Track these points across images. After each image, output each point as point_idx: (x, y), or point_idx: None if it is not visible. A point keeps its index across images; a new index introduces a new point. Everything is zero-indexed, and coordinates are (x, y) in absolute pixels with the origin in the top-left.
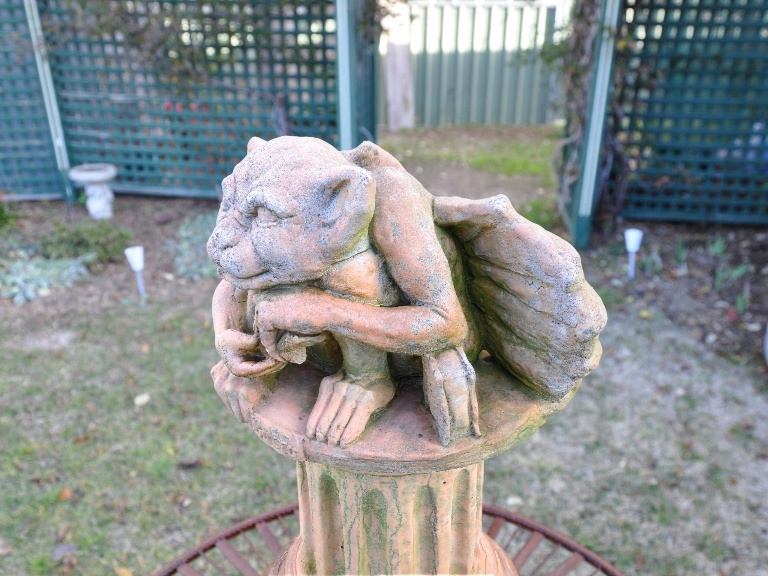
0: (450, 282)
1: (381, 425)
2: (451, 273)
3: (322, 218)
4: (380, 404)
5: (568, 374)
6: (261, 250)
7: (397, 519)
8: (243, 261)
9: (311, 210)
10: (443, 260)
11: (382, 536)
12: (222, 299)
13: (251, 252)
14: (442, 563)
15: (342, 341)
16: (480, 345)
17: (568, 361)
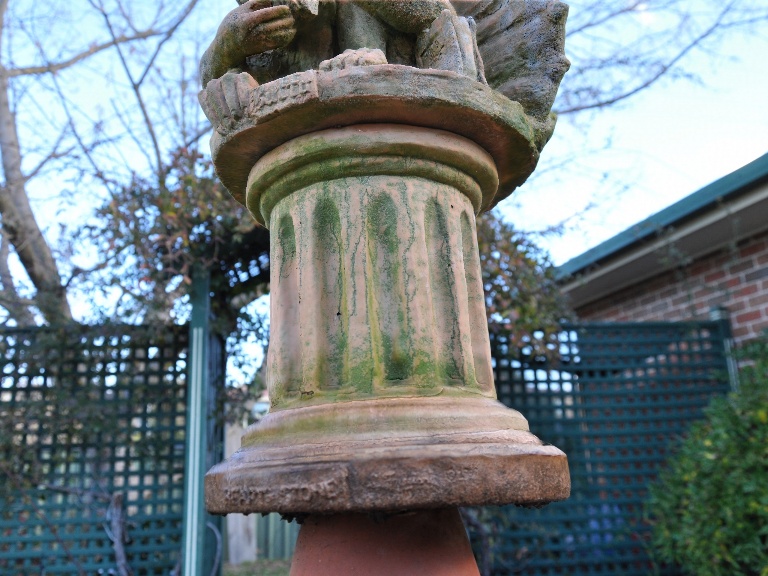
0: None
1: None
2: None
3: None
4: None
5: (548, 72)
6: None
7: (409, 230)
8: None
9: None
10: None
11: (391, 267)
12: None
13: None
14: (462, 314)
15: (349, 14)
16: None
17: (545, 58)
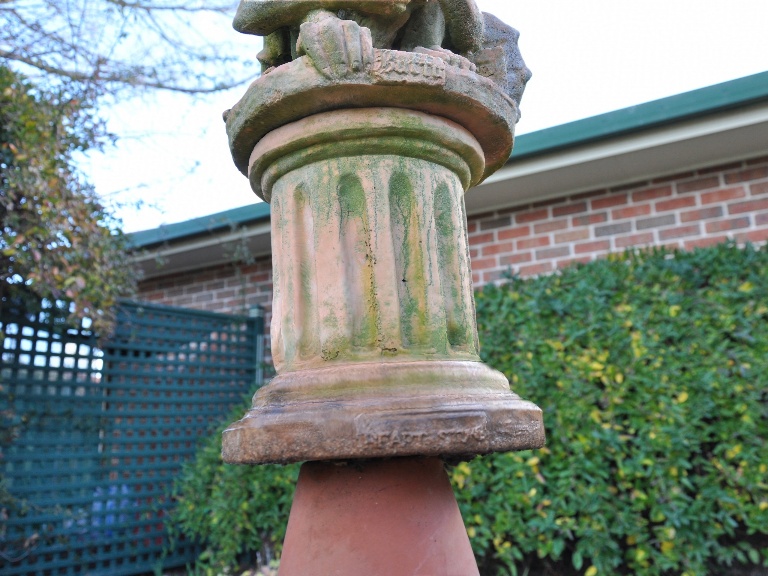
0: None
1: None
2: None
3: None
4: None
5: None
6: None
7: None
8: None
9: None
10: None
11: (445, 248)
12: None
13: None
14: None
15: (433, 12)
16: None
17: None
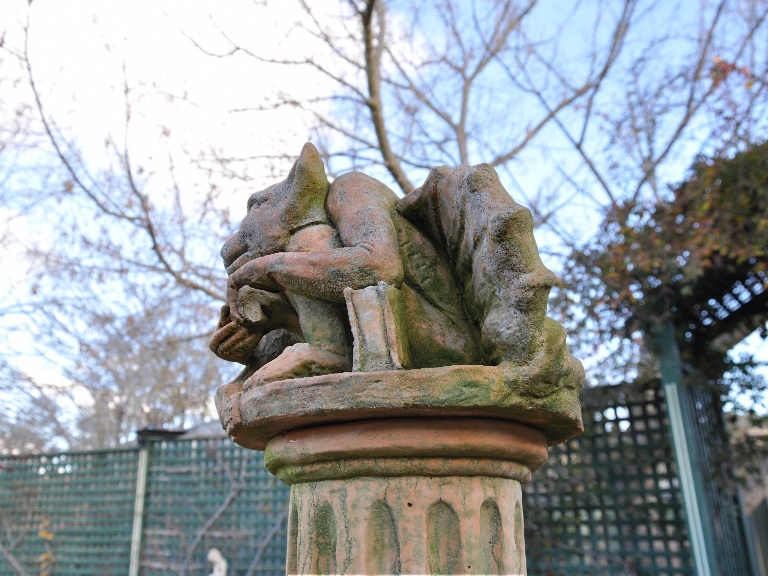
0: (386, 231)
1: None
2: (427, 269)
3: None
4: (317, 358)
5: (511, 303)
6: None
7: (346, 549)
8: (230, 241)
9: (281, 194)
10: (383, 216)
11: None
12: None
13: (237, 234)
14: None
15: (295, 303)
16: (479, 362)
17: (506, 284)
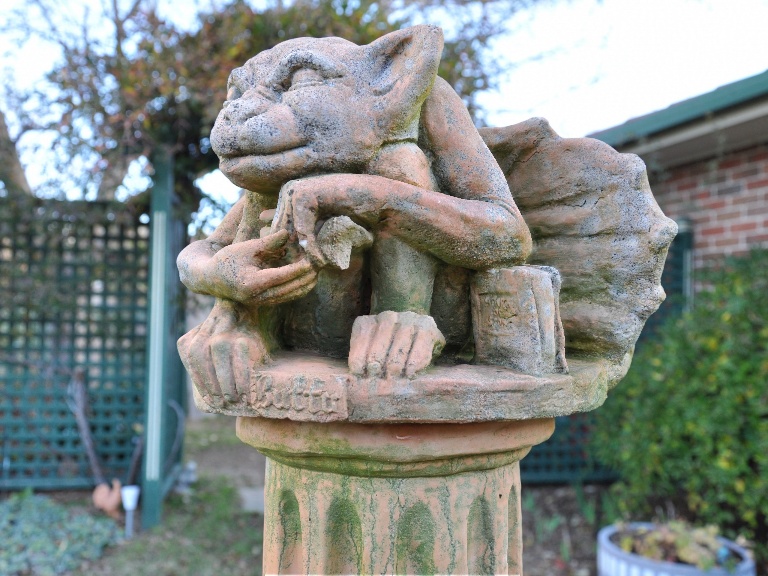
0: None
1: (443, 368)
2: None
3: (373, 87)
4: (440, 338)
5: (636, 310)
6: (305, 107)
7: (449, 553)
8: (278, 122)
9: (362, 75)
10: (497, 163)
11: None
12: (197, 249)
13: (289, 113)
14: None
15: (390, 250)
16: None
17: (635, 291)
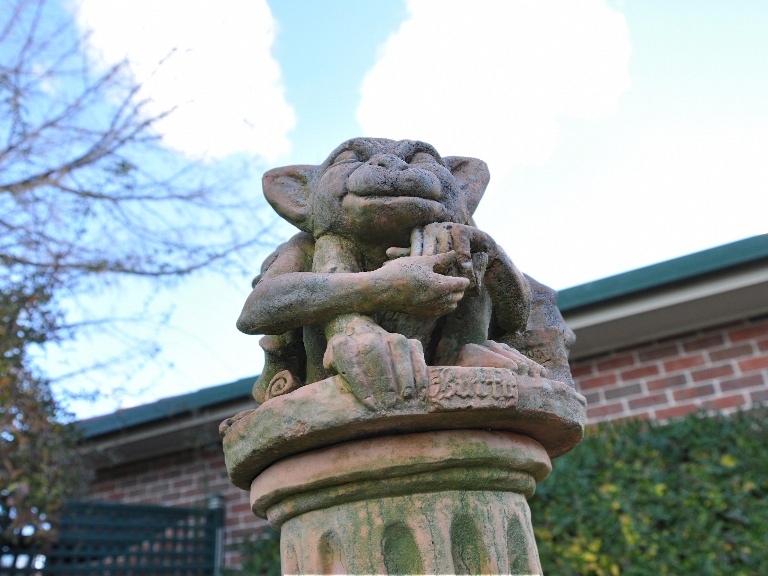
0: None
1: None
2: None
3: None
4: None
5: None
6: (444, 174)
7: None
8: None
9: None
10: None
11: None
12: None
13: None
14: None
15: (480, 297)
16: None
17: None
